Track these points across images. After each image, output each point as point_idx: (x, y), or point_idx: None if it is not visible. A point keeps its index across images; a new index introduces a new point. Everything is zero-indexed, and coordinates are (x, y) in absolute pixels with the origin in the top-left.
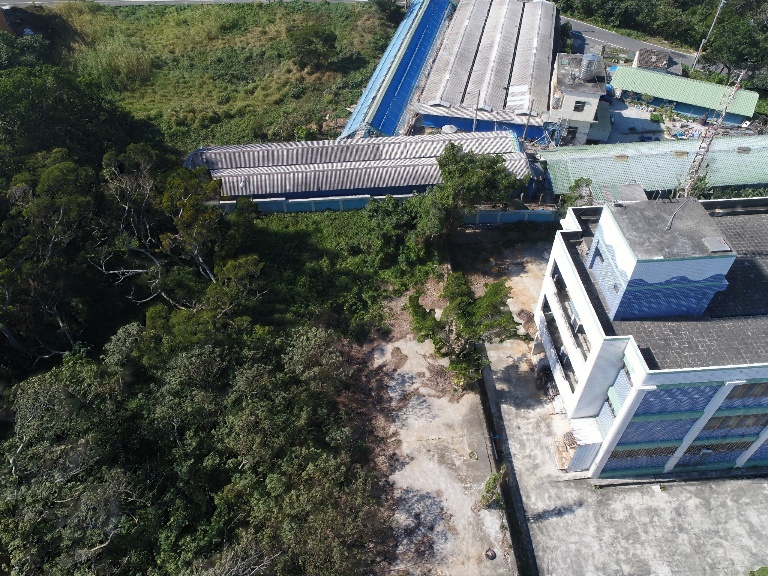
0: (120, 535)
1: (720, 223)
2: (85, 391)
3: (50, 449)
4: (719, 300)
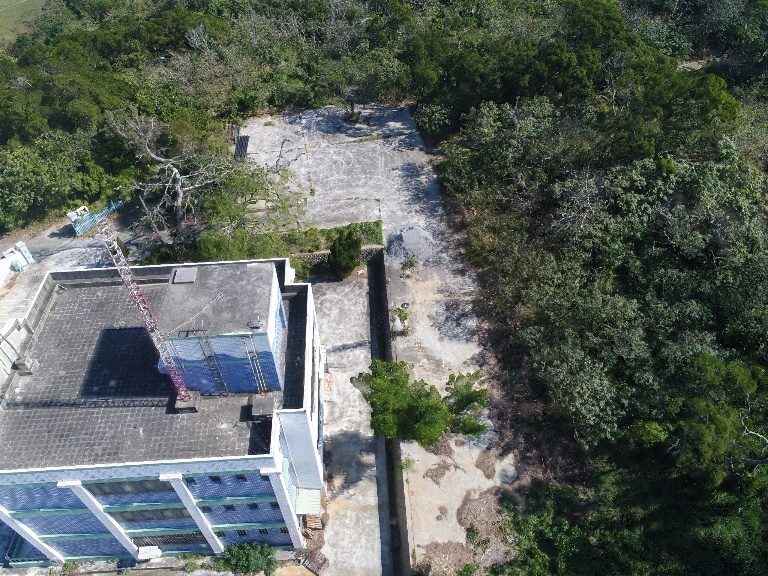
0: (667, 254)
1: (67, 458)
2: (767, 295)
3: (767, 293)
4: None
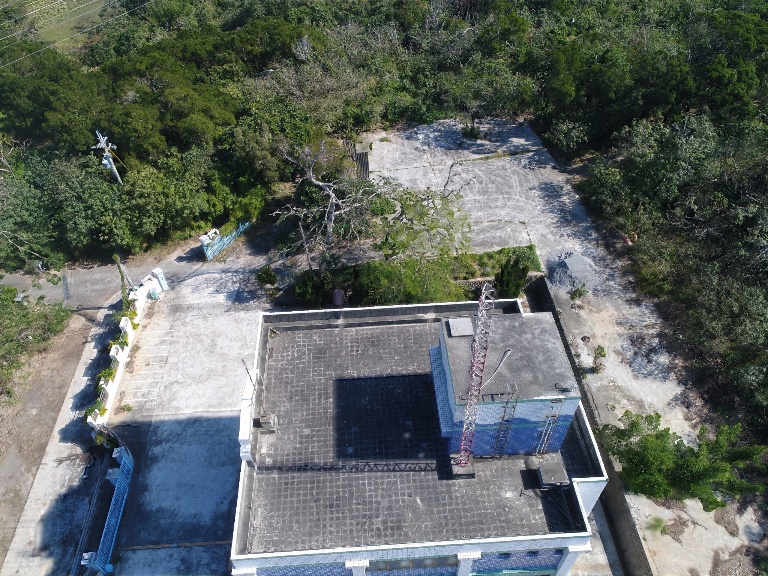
0: None
1: (347, 533)
2: None
3: None
4: (410, 396)
